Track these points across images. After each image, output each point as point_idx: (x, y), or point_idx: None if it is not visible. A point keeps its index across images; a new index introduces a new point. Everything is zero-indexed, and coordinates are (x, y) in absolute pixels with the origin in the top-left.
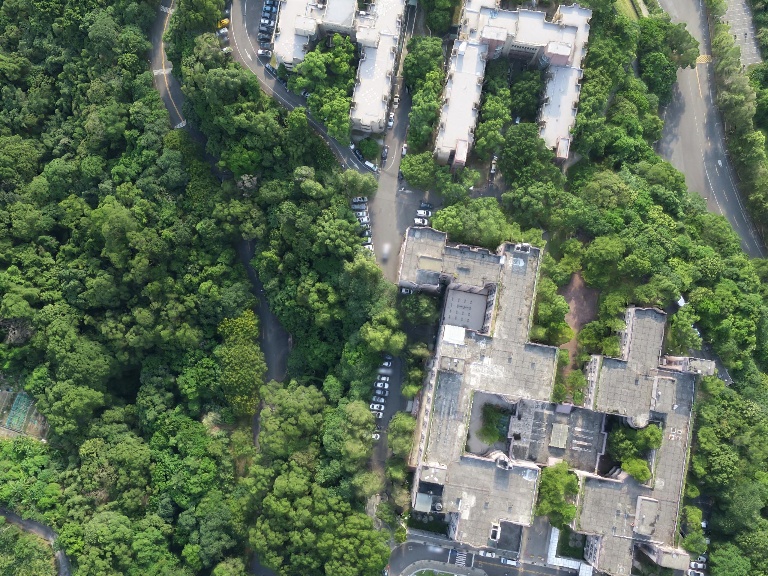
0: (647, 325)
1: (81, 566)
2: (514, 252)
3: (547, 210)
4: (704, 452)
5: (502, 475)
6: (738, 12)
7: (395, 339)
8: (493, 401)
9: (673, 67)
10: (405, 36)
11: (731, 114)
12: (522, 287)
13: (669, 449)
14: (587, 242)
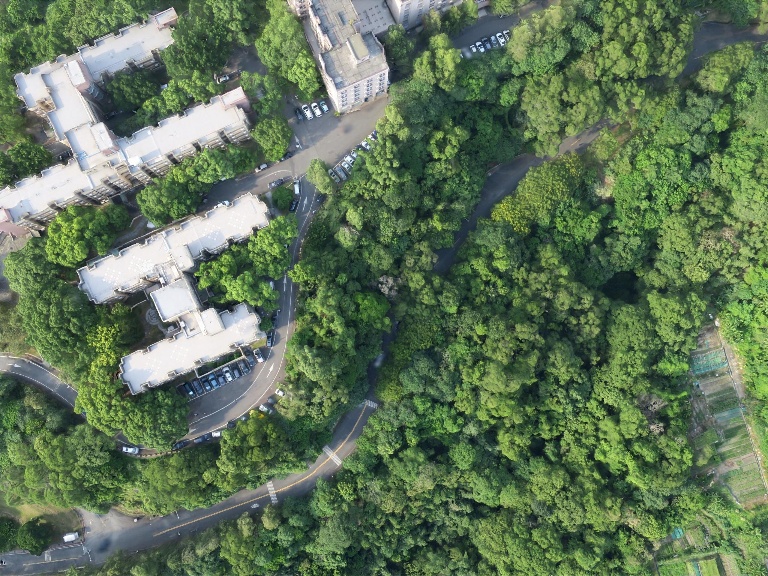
0: None
1: None
2: None
3: None
4: None
5: None
6: None
7: (442, 40)
8: None
9: None
10: None
11: None
12: None
13: None
14: None
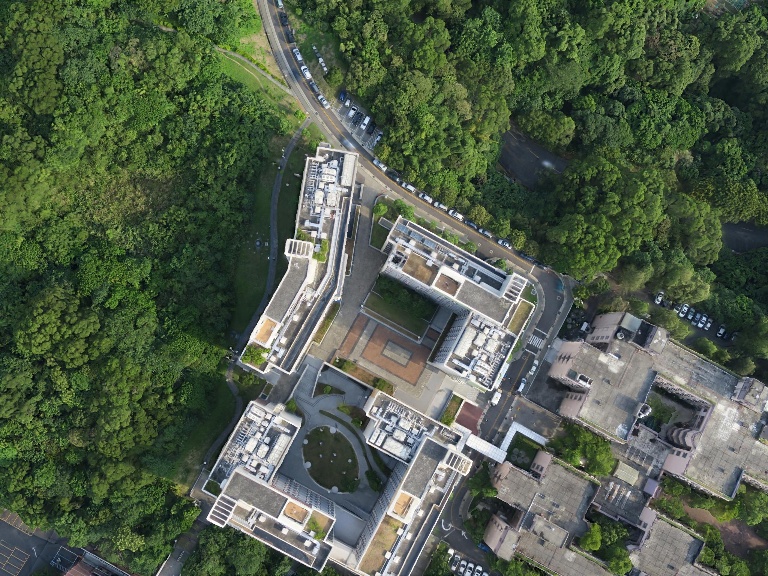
0: None
1: None
2: None
3: None
4: None
5: (629, 405)
6: None
7: None
8: None
9: None
10: None
11: None
12: None
13: None
14: None
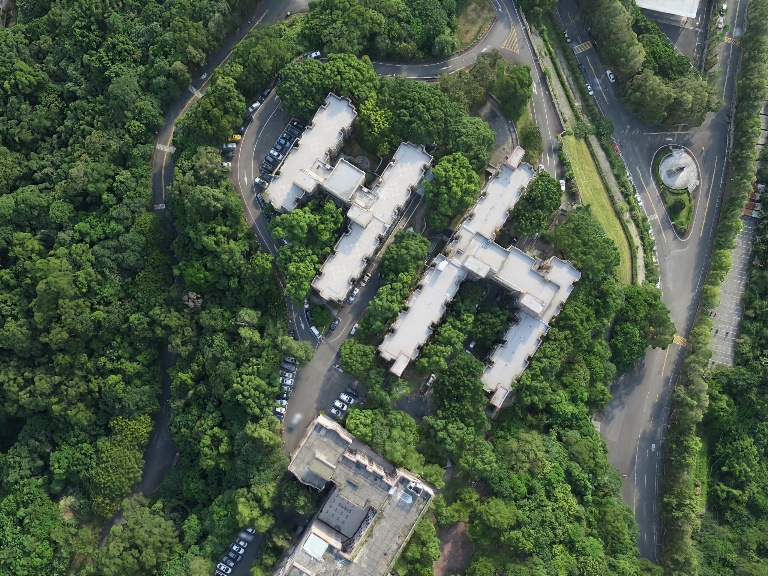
0: None
1: None
2: None
3: (458, 452)
4: None
5: None
6: (729, 308)
7: (260, 524)
8: None
9: (643, 344)
10: (401, 219)
11: (679, 411)
12: (400, 524)
13: None
14: (485, 496)
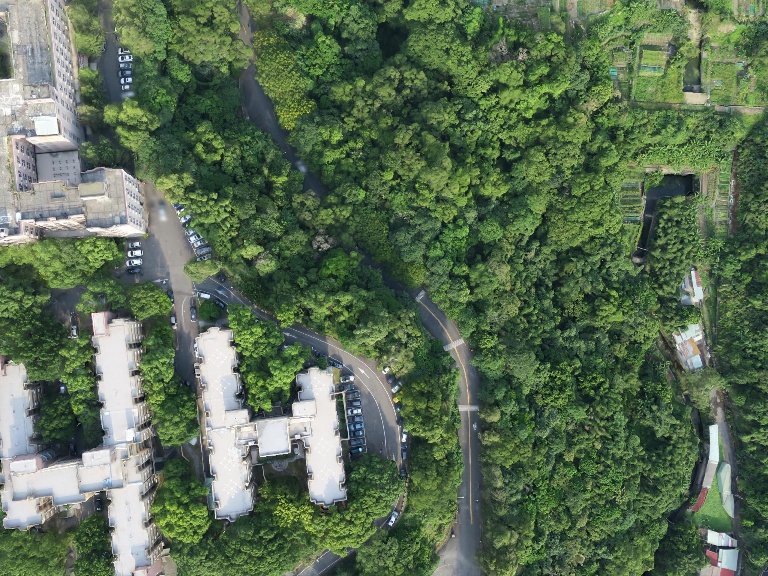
0: None
1: None
2: (9, 229)
3: None
4: None
5: None
6: None
7: (111, 111)
8: None
9: None
10: None
11: None
12: None
13: None
14: None
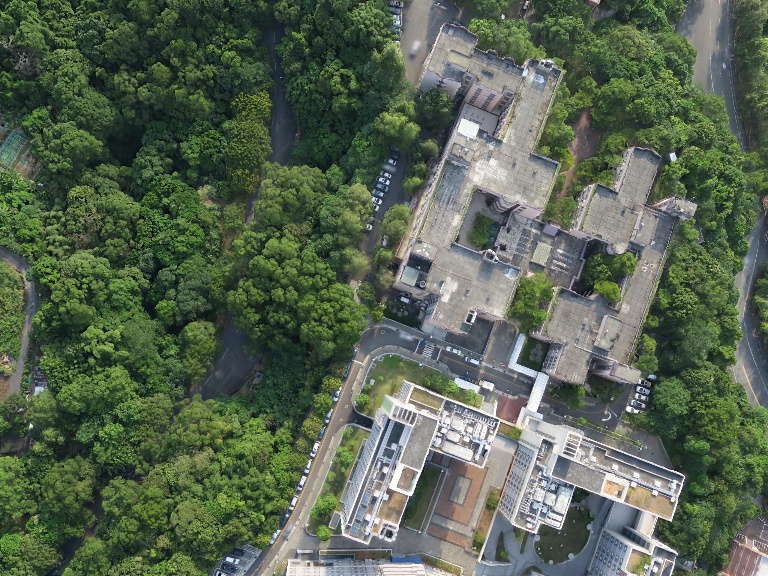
0: (642, 165)
1: (55, 291)
2: (537, 68)
3: (572, 44)
4: (671, 286)
5: (486, 269)
6: None
7: (411, 125)
8: (486, 213)
9: None
10: None
11: (745, 18)
12: (538, 102)
13: (640, 279)
14: (601, 84)
